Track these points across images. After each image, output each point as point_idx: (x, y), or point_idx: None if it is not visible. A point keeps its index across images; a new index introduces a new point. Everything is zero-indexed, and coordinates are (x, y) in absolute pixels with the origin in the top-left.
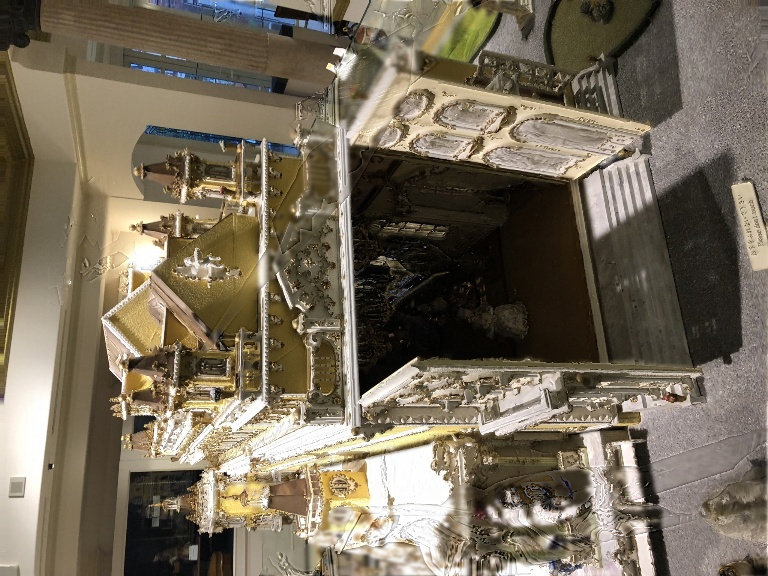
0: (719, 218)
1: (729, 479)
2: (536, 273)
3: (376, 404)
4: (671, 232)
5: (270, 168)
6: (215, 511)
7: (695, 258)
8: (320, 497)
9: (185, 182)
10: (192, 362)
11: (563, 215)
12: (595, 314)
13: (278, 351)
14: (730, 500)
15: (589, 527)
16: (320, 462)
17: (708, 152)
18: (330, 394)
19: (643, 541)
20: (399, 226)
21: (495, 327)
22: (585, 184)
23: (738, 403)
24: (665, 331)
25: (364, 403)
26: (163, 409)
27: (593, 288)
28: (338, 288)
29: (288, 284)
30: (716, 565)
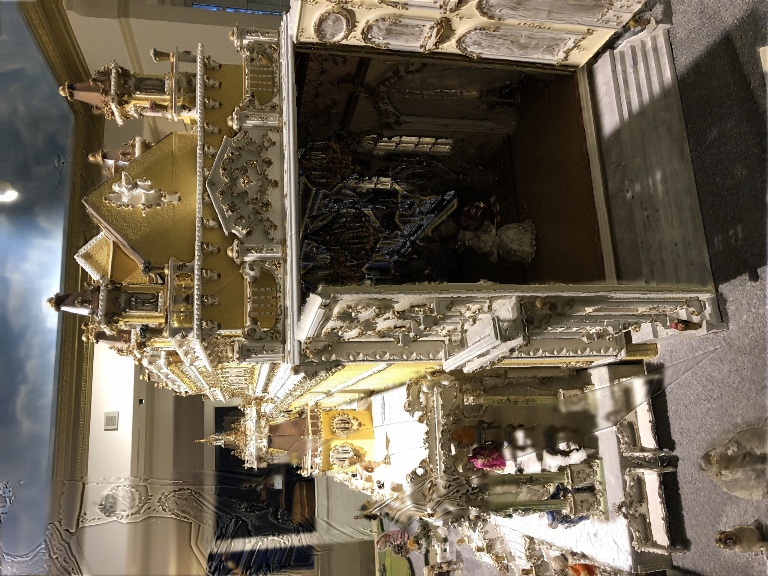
0: (747, 95)
1: (752, 423)
2: (544, 185)
3: (311, 339)
4: (692, 120)
5: (204, 76)
6: (258, 447)
7: (719, 150)
8: (318, 437)
9: (110, 98)
10: (119, 297)
11: (569, 112)
12: (602, 228)
13: (214, 283)
14: (738, 450)
15: (402, 504)
16: (343, 400)
17: (736, 9)
18: (269, 329)
19: (654, 493)
20: (394, 141)
21: (500, 250)
22: (594, 71)
23: (764, 330)
24: (682, 244)
25: (300, 338)
26: (126, 348)
27: (600, 197)
28: (281, 209)
29: (221, 207)
30: (735, 524)
